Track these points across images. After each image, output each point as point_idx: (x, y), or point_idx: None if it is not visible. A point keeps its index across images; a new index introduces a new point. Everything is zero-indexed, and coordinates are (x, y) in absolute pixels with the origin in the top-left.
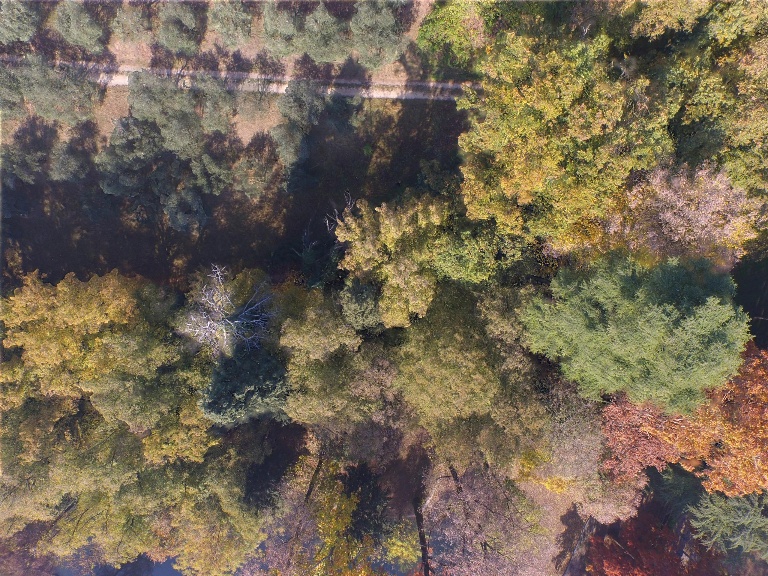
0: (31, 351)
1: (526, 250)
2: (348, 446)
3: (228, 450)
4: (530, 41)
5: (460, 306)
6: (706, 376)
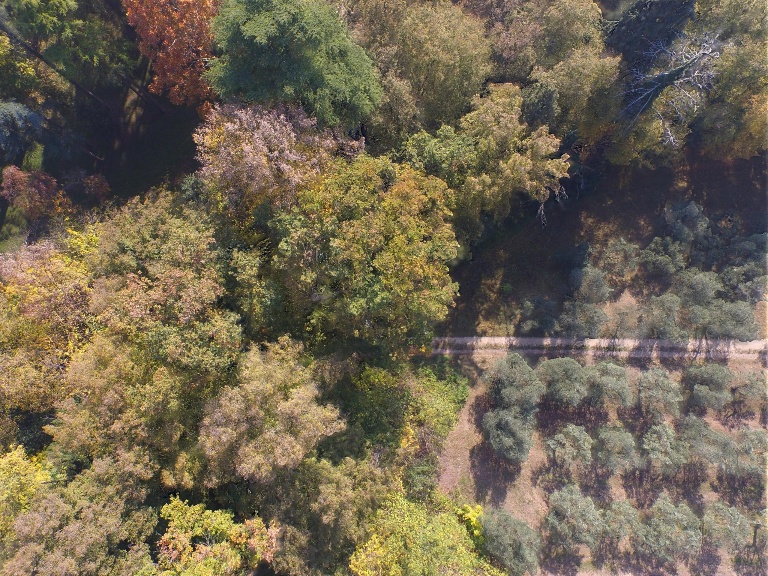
0: None
1: None
2: None
3: None
4: None
5: (424, 125)
6: None
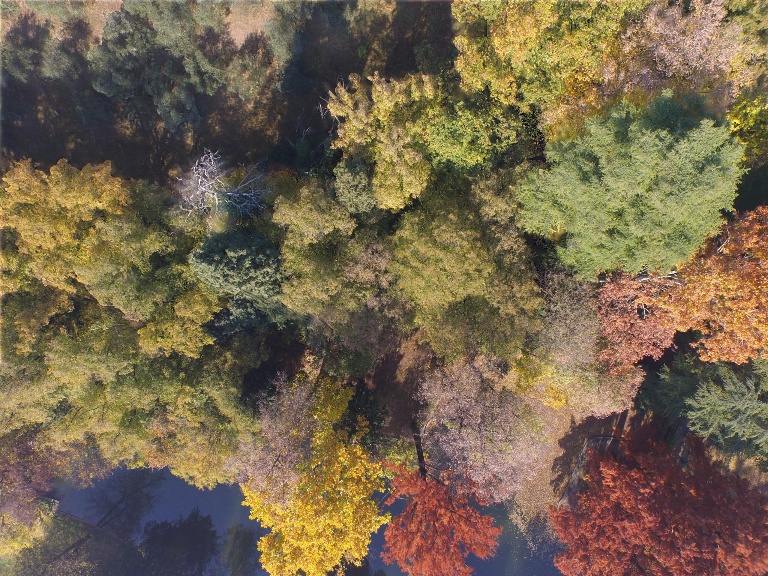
0: (24, 231)
1: (521, 132)
2: (343, 338)
3: (224, 353)
4: None
5: None
6: (700, 200)
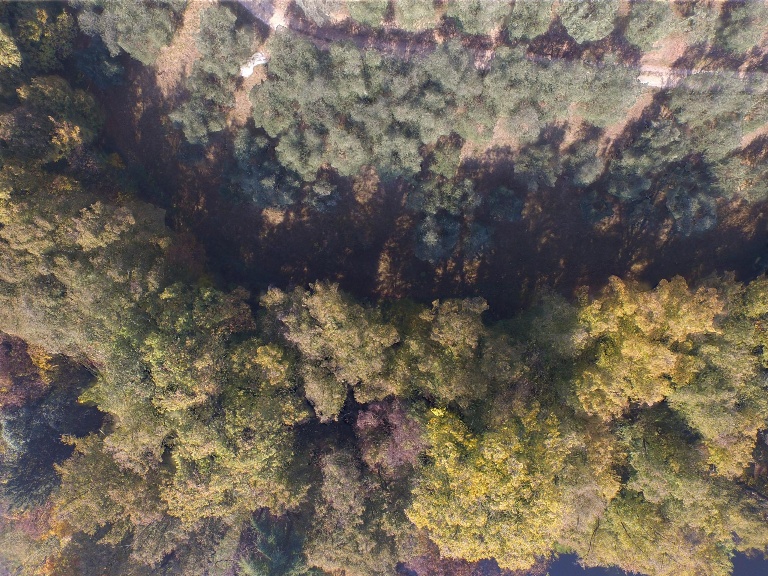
0: (657, 361)
1: None
2: None
3: None
4: None
5: None
6: None
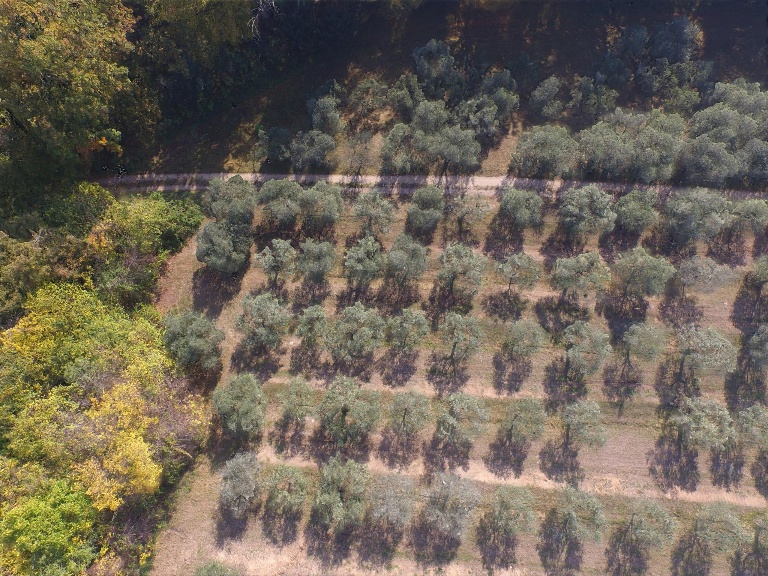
0: None
1: None
2: None
3: None
4: (37, 90)
5: None
6: None
